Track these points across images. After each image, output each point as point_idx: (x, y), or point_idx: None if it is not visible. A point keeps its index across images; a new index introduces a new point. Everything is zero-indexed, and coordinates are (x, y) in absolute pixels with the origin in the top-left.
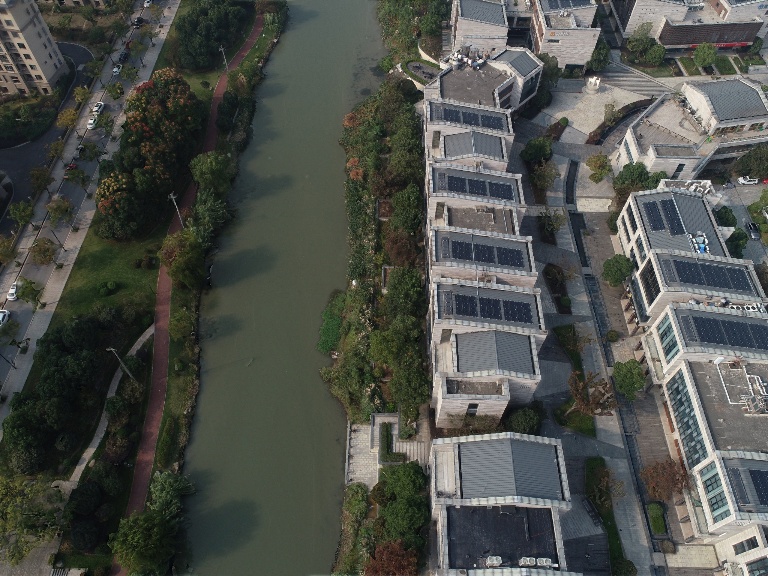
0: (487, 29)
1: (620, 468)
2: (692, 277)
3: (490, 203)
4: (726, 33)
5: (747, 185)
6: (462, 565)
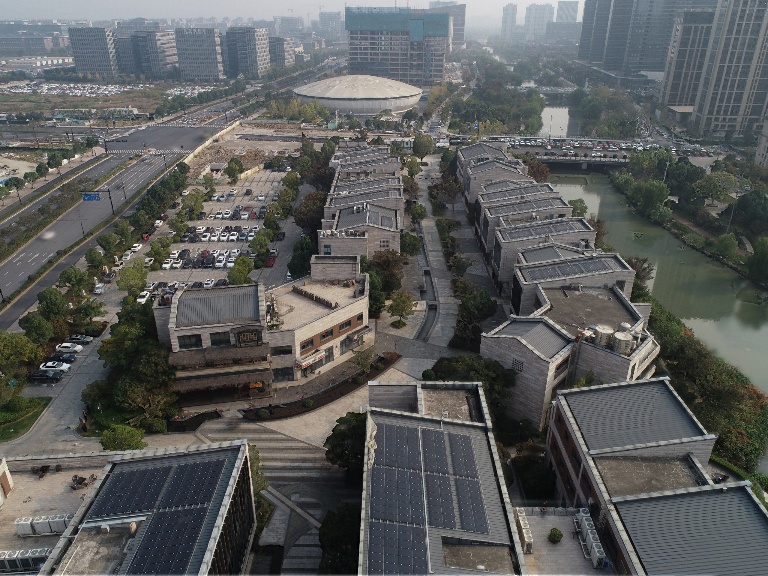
0: None
1: None
2: None
3: None
4: None
5: None
6: None
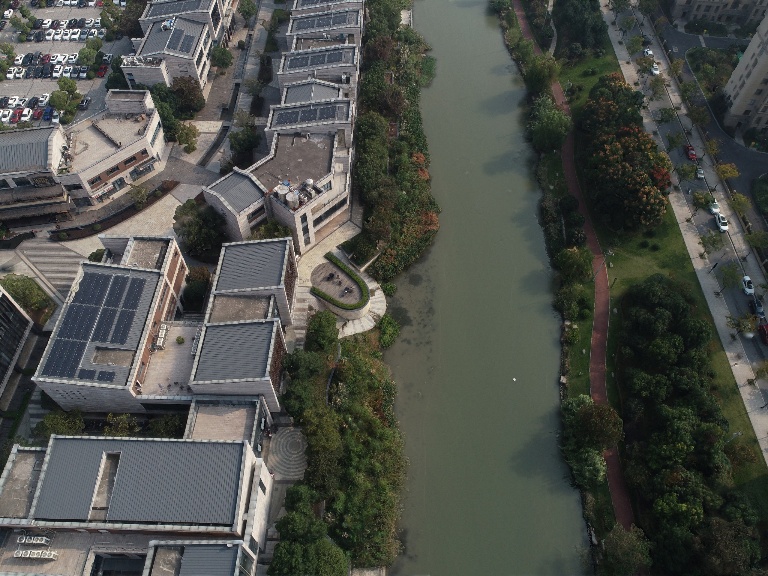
0: None
1: (267, 1)
2: (191, 4)
3: None
4: None
5: None
6: None
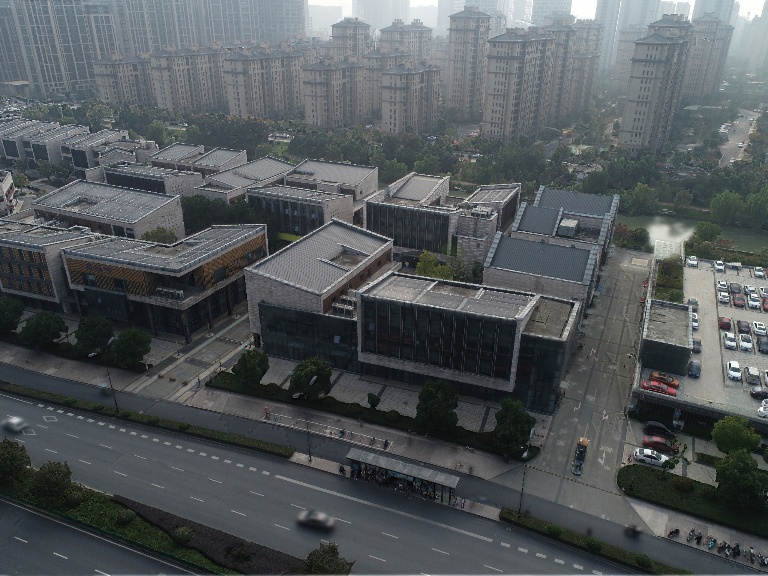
0: None
1: None
2: None
3: None
4: None
5: None
6: None
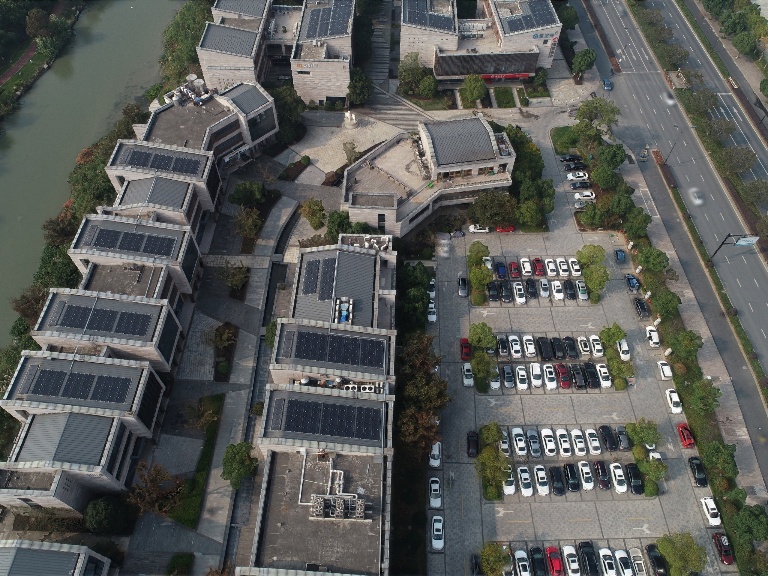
0: (231, 60)
1: (208, 567)
2: (312, 352)
3: (137, 260)
4: (502, 64)
5: (478, 233)
6: None
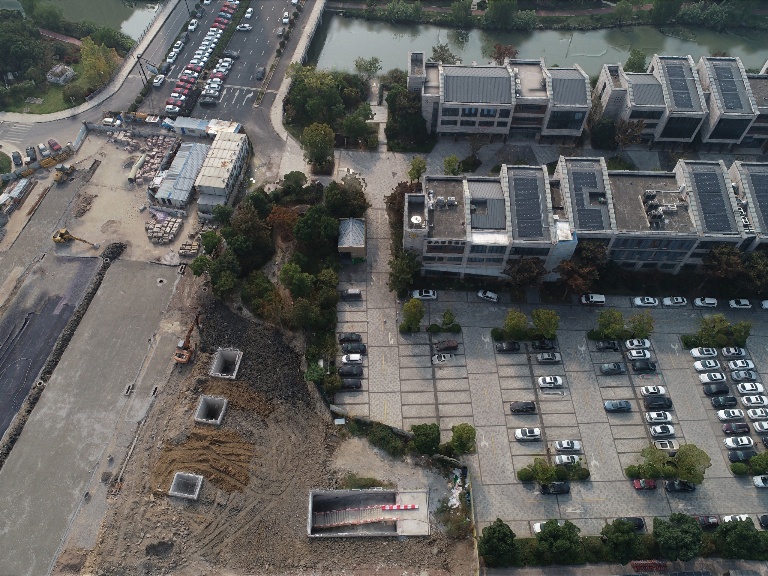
0: None
1: None
2: (760, 185)
3: None
4: None
5: None
6: (511, 67)
